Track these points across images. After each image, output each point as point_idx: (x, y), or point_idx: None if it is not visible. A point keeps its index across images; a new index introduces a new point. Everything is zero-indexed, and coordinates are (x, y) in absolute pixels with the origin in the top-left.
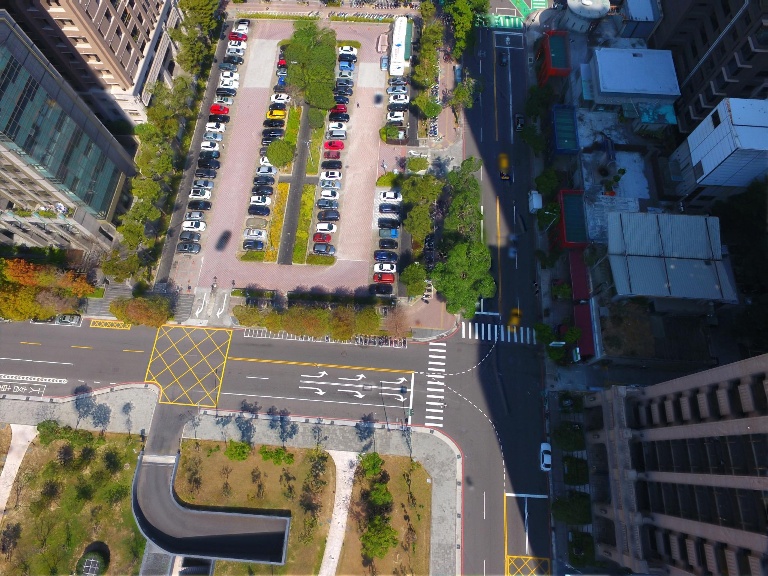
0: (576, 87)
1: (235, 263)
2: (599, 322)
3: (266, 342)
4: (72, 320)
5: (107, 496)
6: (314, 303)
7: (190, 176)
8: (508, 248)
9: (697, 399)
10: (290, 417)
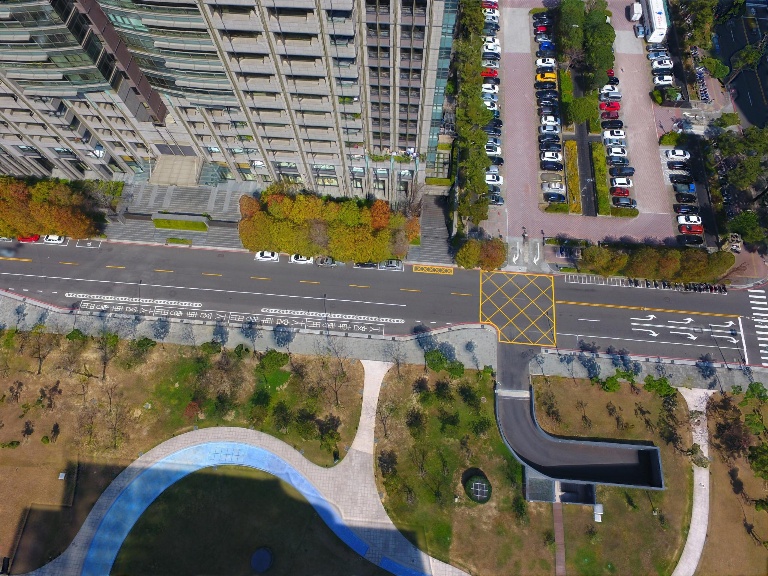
0: None
1: (539, 214)
2: None
3: (589, 287)
4: (398, 265)
5: (471, 426)
6: (627, 252)
7: None
8: None
9: None
10: (630, 356)
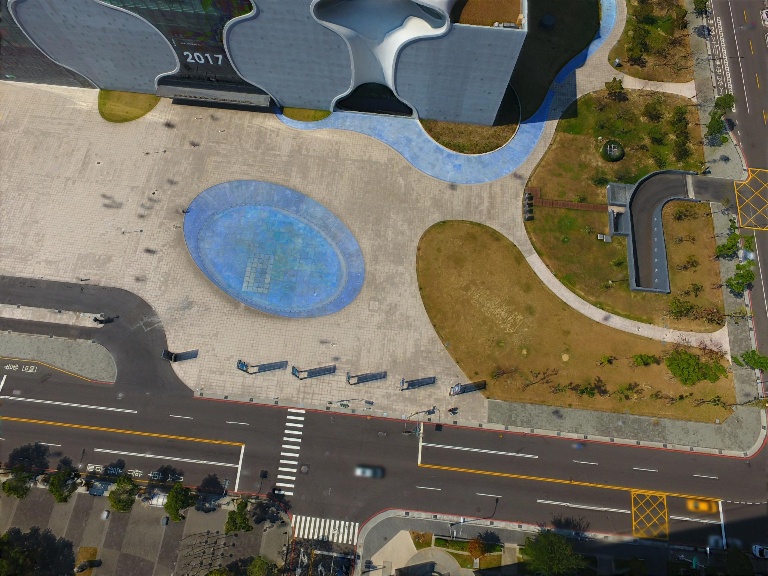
0: None
1: None
2: None
3: None
4: None
5: None
6: None
7: None
8: None
9: None
10: (747, 291)
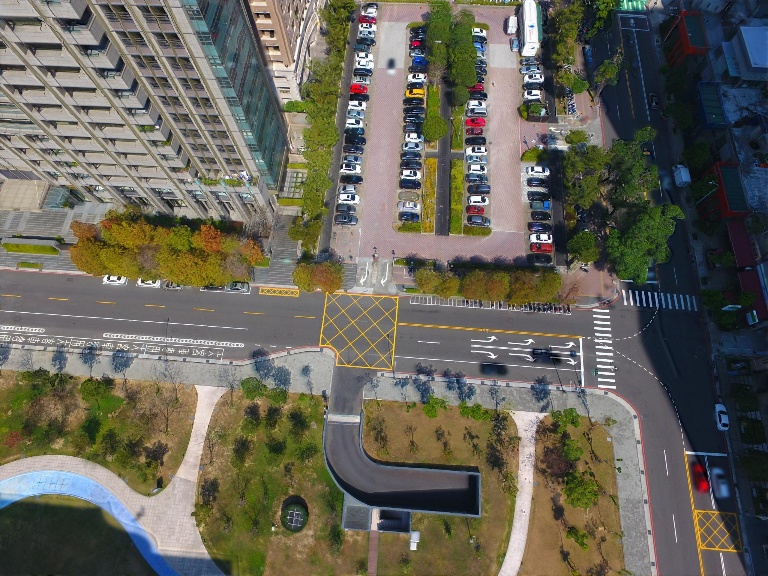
0: (717, 65)
1: (392, 234)
2: None
3: (433, 309)
4: (243, 287)
5: (298, 453)
6: None
7: (338, 152)
8: None
9: None
10: (466, 379)
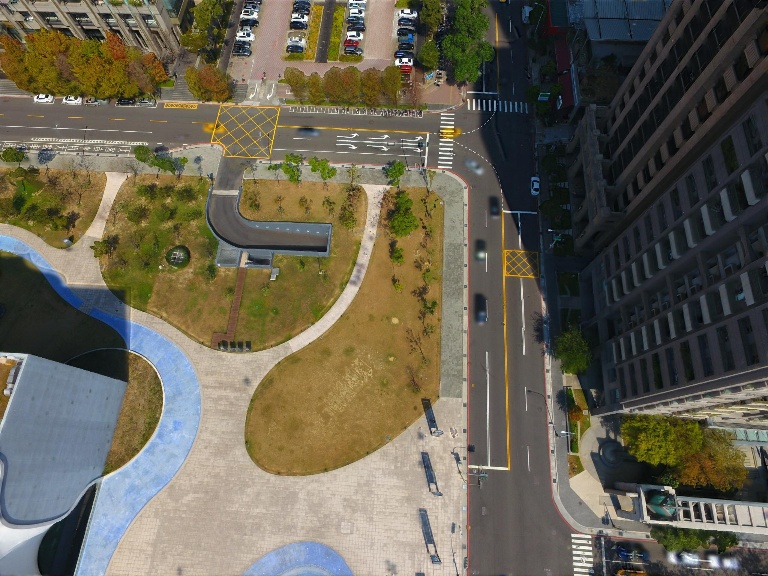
0: None
1: (280, 63)
2: (577, 77)
3: (308, 115)
4: (150, 101)
5: (186, 216)
6: None
7: (240, 4)
8: (505, 48)
9: (644, 68)
10: (329, 164)
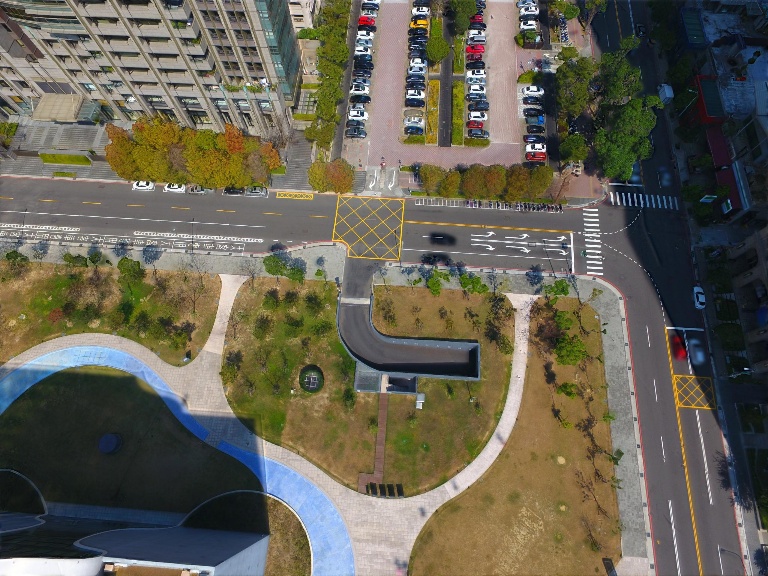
0: None
1: (399, 146)
2: (746, 179)
3: (436, 209)
4: (262, 191)
5: (314, 329)
6: None
7: (347, 76)
8: None
9: None
10: (466, 268)
